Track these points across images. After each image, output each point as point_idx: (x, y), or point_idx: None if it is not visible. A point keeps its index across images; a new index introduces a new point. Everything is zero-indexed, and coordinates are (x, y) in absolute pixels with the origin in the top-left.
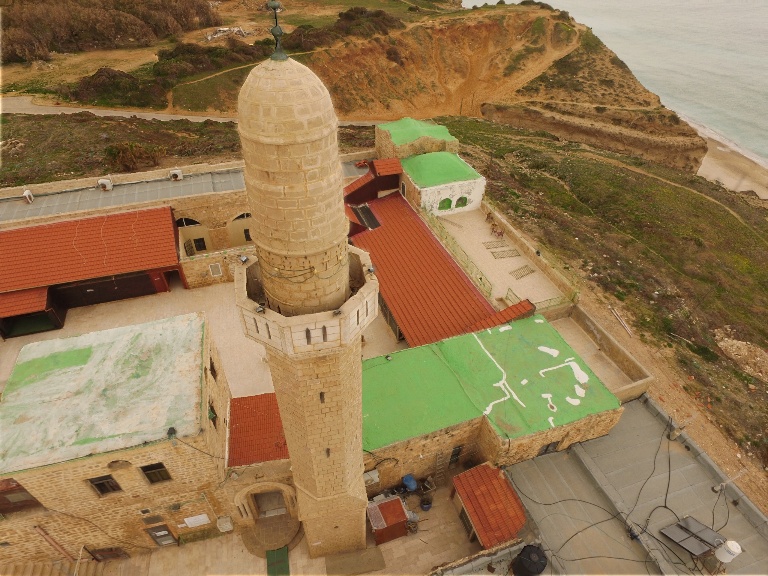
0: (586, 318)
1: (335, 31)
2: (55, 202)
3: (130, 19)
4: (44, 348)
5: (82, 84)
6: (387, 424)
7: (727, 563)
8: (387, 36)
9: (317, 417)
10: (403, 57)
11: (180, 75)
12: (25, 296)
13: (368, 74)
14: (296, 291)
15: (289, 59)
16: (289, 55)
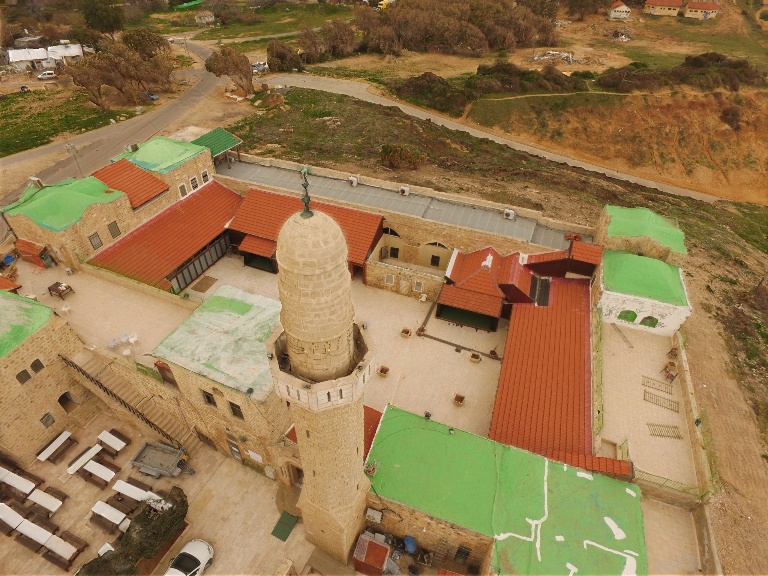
0: (705, 526)
1: (668, 76)
2: (317, 183)
3: (474, 31)
4: (231, 292)
5: (407, 82)
6: (407, 484)
7: None
8: (734, 93)
9: (305, 444)
10: (743, 121)
11: (486, 91)
12: (265, 243)
13: (684, 131)
14: (294, 356)
15: (311, 218)
16: (600, 93)
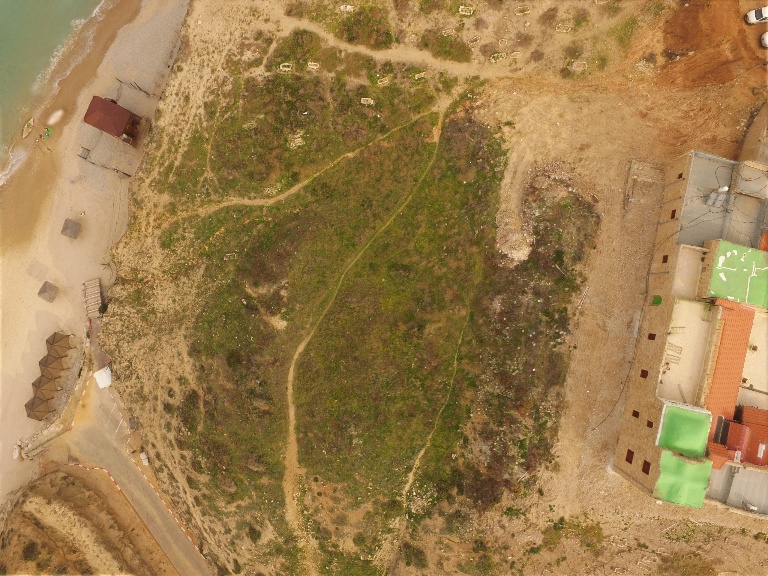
0: None
1: None
2: None
3: None
4: None
5: None
6: None
7: (708, 189)
8: None
9: None
10: None
11: None
12: None
13: None
14: None
15: None
16: None
